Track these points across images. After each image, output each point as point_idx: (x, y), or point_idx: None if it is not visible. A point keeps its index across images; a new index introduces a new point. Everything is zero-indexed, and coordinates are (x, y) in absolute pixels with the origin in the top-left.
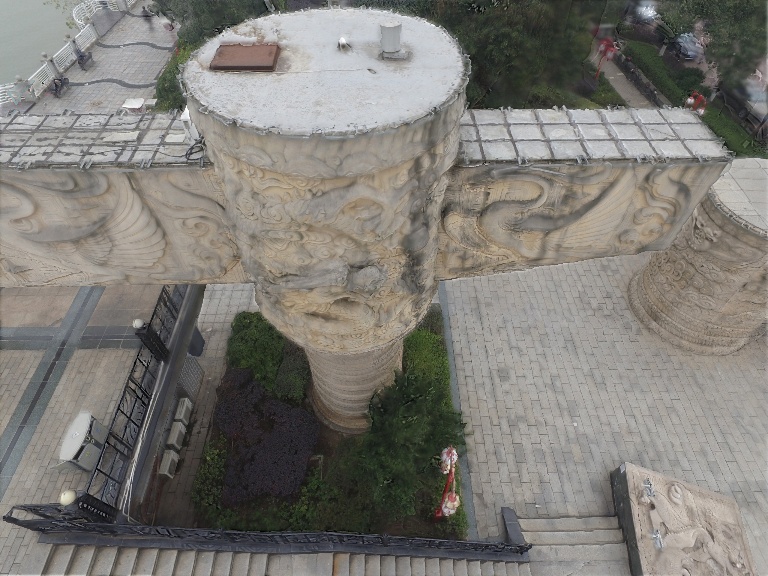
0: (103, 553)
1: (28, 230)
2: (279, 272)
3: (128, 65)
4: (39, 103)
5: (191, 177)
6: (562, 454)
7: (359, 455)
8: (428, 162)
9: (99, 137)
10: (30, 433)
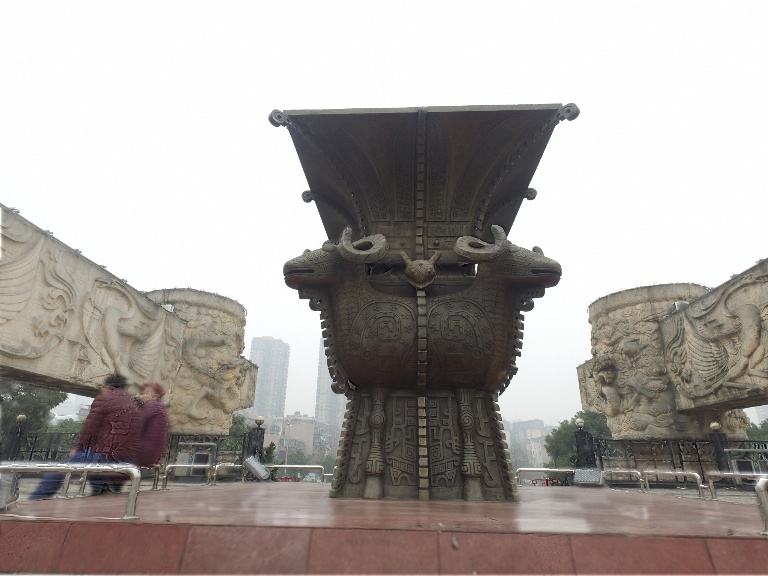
0: None
1: (121, 327)
2: None
3: None
4: None
5: (179, 325)
6: None
7: None
8: None
9: None
10: None
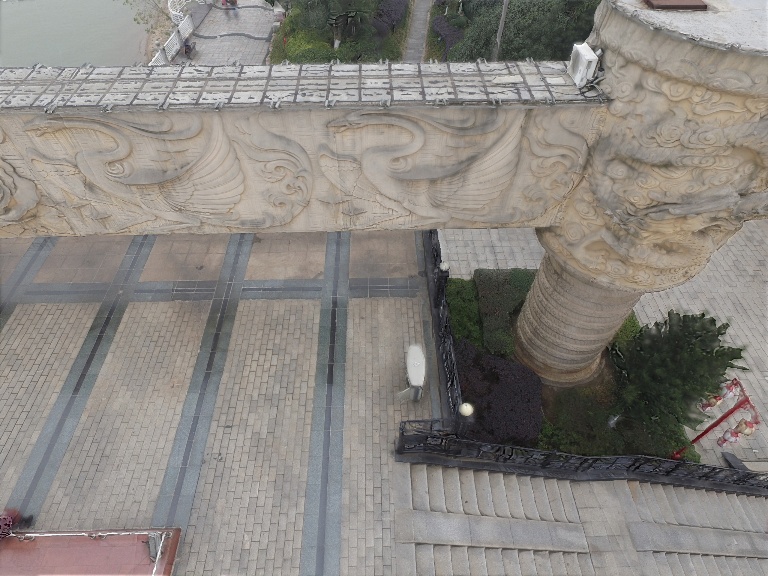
0: (447, 473)
1: (399, 169)
2: (648, 203)
3: (231, 54)
4: None
5: (580, 114)
6: (763, 405)
7: (636, 391)
8: None
9: (485, 80)
10: (342, 370)
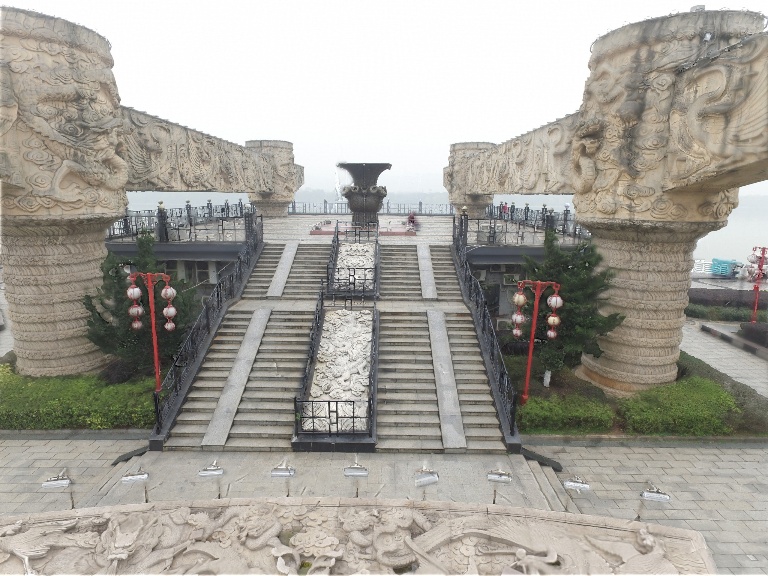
0: None
1: None
2: None
3: None
4: (733, 280)
5: None
6: None
7: None
8: (644, 54)
9: None
10: None
